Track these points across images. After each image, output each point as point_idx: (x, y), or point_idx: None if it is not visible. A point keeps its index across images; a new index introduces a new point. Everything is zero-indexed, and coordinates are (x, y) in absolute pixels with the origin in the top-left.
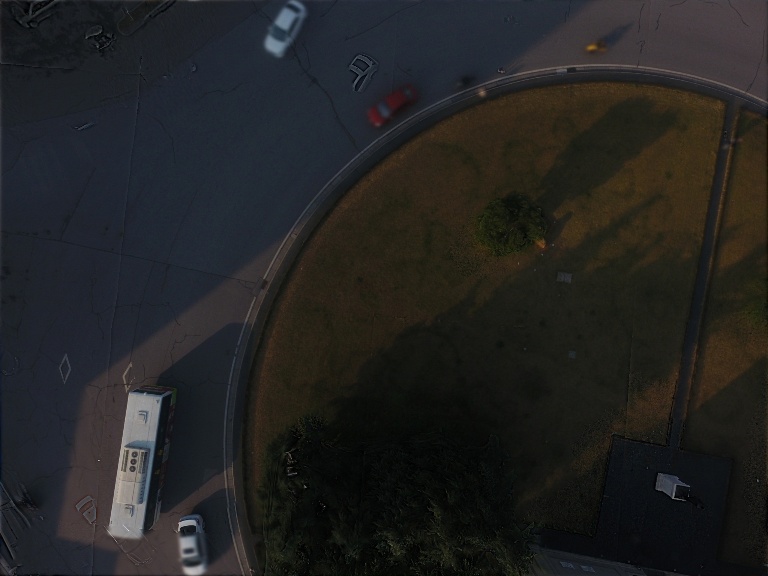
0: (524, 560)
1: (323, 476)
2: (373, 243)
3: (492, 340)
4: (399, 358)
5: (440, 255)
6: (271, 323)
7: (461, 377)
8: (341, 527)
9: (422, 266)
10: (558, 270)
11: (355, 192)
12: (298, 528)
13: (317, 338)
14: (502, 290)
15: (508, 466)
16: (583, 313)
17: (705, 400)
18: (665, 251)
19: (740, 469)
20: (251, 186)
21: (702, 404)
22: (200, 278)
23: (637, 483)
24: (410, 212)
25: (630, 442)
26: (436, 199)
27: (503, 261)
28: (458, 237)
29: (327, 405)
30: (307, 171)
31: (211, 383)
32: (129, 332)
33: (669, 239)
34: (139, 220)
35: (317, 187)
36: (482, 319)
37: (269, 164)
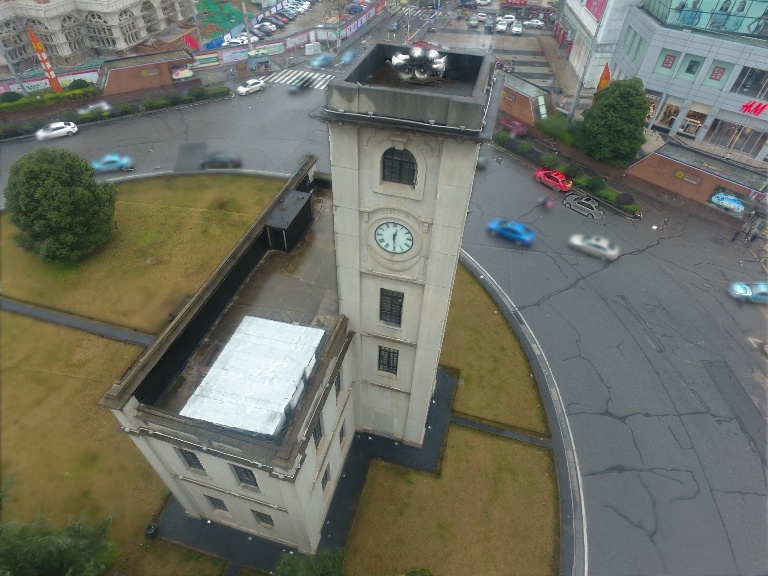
0: None
1: None
2: None
3: None
4: None
5: None
6: None
7: None
8: None
9: None
10: None
11: None
12: None
13: None
14: None
15: None
16: None
17: (121, 312)
18: None
19: None
20: None
21: (123, 315)
22: None
23: None
24: None
25: None
26: None
27: None
28: None
29: None
30: None
31: None
32: None
33: None
34: None
35: None
36: None
37: None
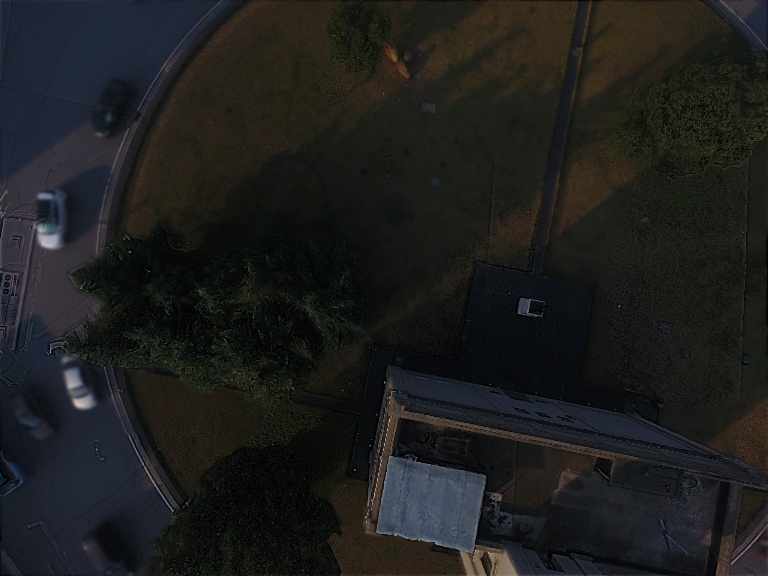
0: (331, 309)
1: (159, 256)
2: (242, 75)
3: (357, 167)
4: (266, 185)
5: (307, 86)
6: (143, 152)
7: (326, 203)
8: (156, 280)
9: (289, 96)
10: (423, 101)
11: (227, 27)
12: (114, 279)
13: (186, 166)
14: (367, 119)
15: (371, 289)
16: (446, 141)
17: (567, 227)
18: (528, 82)
19: (602, 295)
20: (127, 23)
21: (564, 231)
22: (76, 110)
23: (499, 308)
24: (279, 45)
25: (492, 268)
26: (304, 33)
27: (368, 91)
28: (325, 69)
29: (195, 230)
30: (181, 9)
31: (84, 210)
32: (5, 160)
33: (532, 71)
34: (18, 55)
35: (190, 23)
36: (347, 147)
37: (145, 2)
